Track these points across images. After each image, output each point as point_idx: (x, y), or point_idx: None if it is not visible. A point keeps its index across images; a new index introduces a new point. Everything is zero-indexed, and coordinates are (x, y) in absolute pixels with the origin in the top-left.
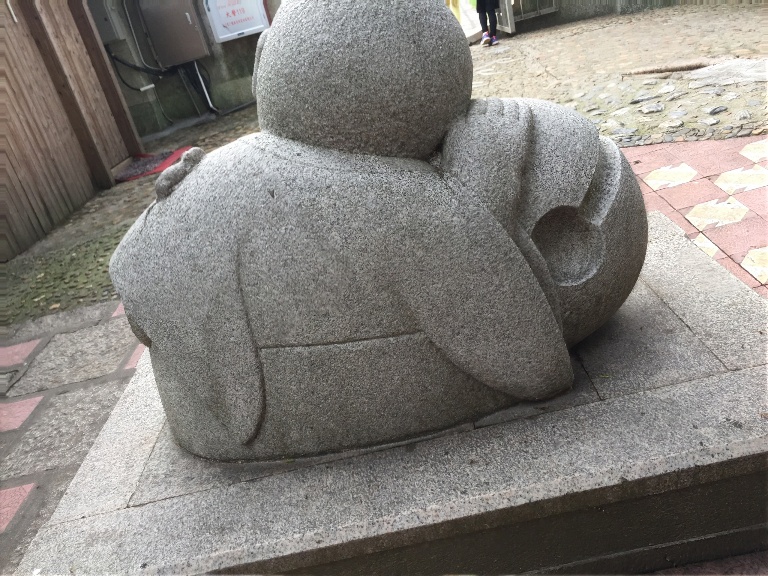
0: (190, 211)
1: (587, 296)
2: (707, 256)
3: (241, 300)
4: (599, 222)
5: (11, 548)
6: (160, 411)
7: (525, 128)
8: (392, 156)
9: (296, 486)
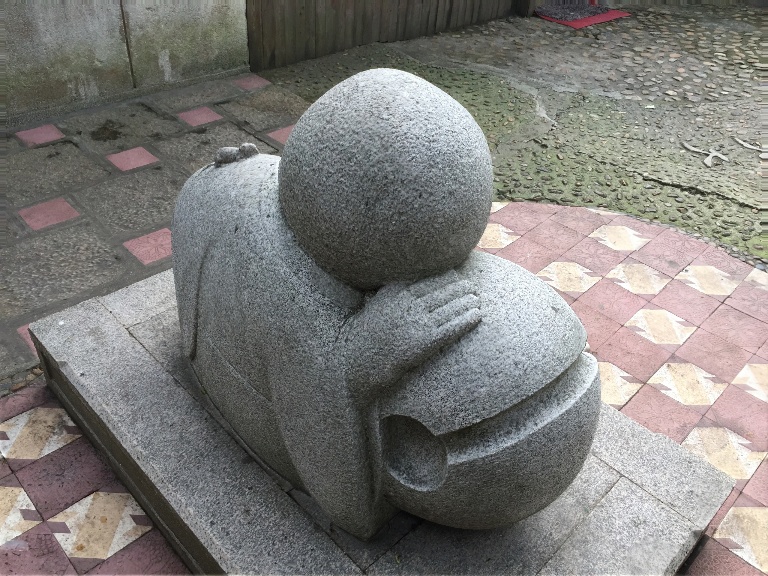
0: (208, 193)
1: (413, 498)
2: (662, 570)
3: (198, 278)
4: (450, 461)
5: (136, 279)
6: None
7: (432, 339)
8: (327, 271)
9: (180, 411)
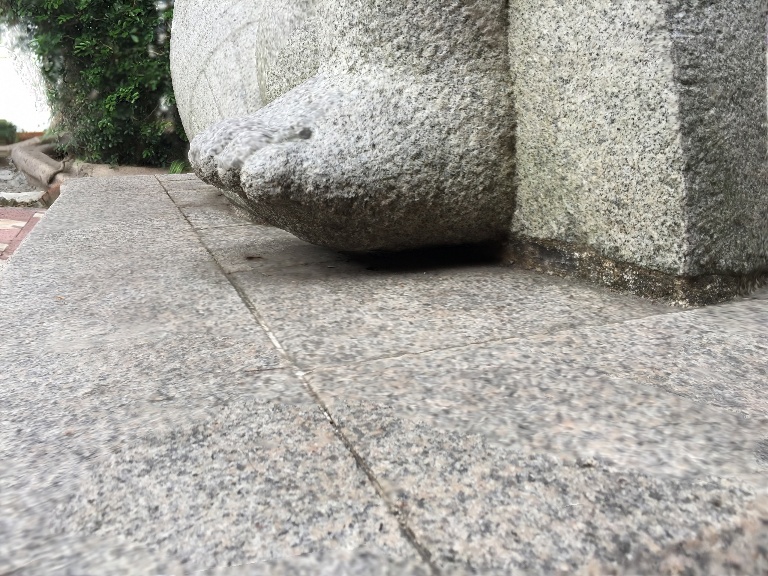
0: None
1: None
2: None
3: None
4: None
5: None
6: (759, 315)
7: None
8: None
9: None
